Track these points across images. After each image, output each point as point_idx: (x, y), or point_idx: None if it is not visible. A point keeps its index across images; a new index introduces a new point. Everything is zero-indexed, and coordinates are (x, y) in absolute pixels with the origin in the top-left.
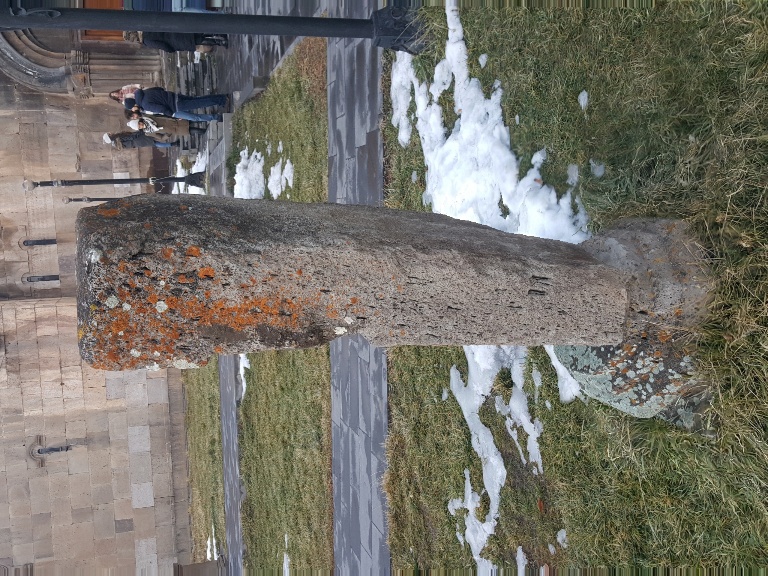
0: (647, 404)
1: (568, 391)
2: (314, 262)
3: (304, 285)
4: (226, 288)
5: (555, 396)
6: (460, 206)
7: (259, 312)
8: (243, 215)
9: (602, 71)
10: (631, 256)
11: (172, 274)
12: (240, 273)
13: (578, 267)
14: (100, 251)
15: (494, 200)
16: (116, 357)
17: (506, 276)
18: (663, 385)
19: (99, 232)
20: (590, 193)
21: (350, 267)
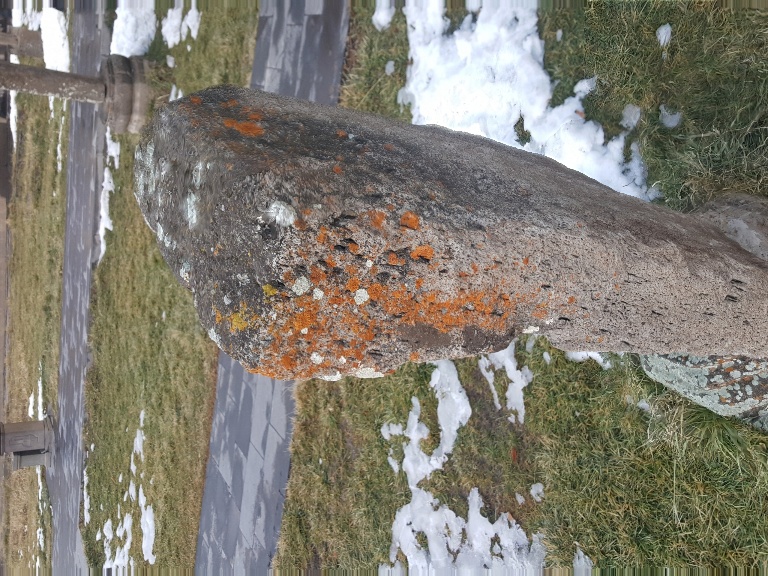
0: (739, 405)
1: None
2: (544, 248)
3: (526, 277)
4: (443, 276)
5: (559, 350)
6: (461, 118)
7: (471, 310)
8: (429, 159)
9: (702, 7)
10: (765, 247)
11: (383, 252)
12: (463, 257)
13: (766, 270)
14: (293, 208)
15: (510, 121)
16: (292, 363)
17: (714, 279)
18: (767, 390)
19: (276, 172)
20: (657, 144)
21: (579, 258)
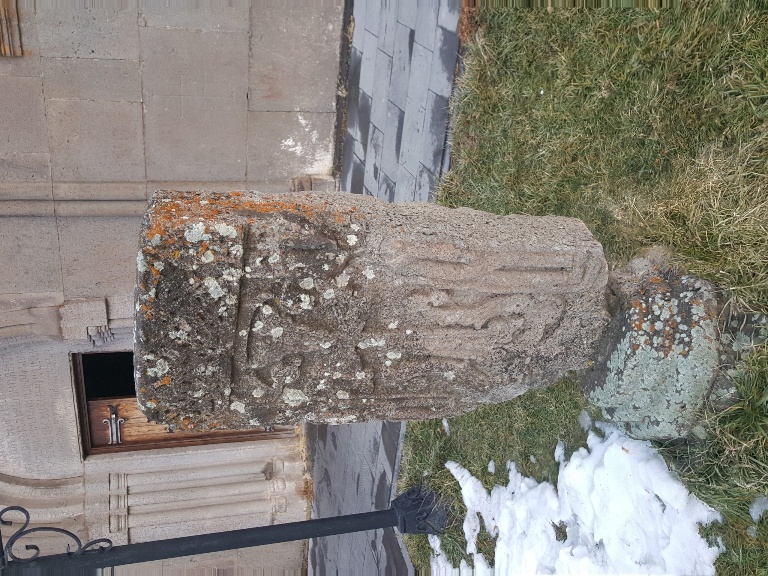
0: (695, 344)
1: (705, 571)
2: None
3: None
4: None
5: None
6: None
7: None
8: None
9: None
10: None
11: None
12: None
13: None
14: None
15: (551, 539)
16: None
17: None
18: (689, 313)
19: None
20: None
21: None
